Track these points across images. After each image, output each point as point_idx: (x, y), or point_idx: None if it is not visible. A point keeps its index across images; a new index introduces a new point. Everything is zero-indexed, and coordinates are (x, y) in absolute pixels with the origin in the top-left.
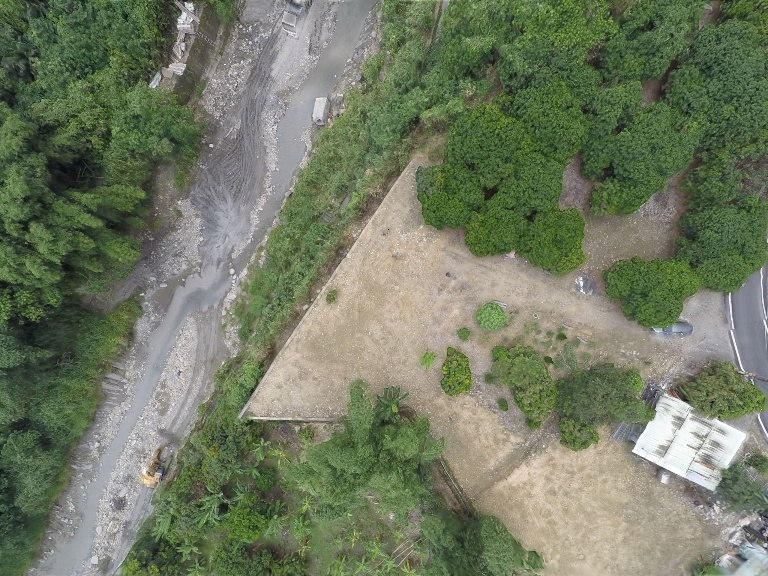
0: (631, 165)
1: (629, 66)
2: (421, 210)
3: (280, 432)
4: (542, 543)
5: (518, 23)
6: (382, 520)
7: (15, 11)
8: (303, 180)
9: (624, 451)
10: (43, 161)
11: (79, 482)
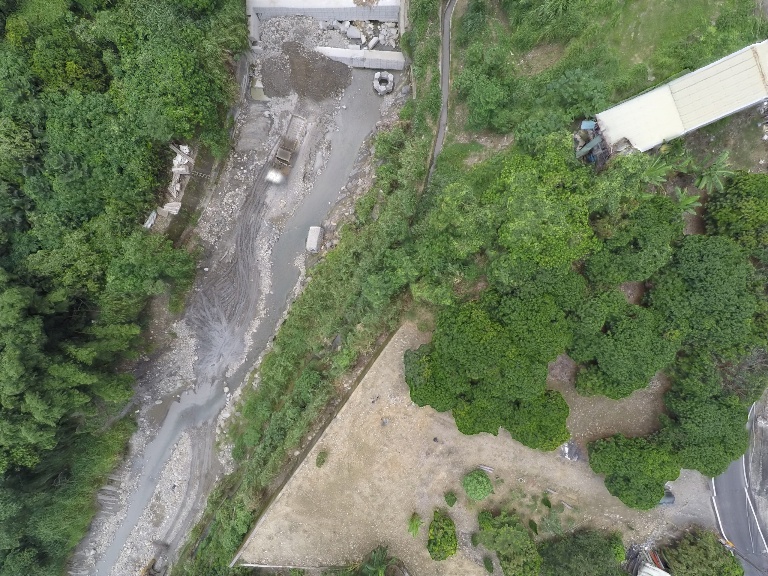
0: (614, 369)
1: (613, 277)
2: None
3: None
4: None
5: (503, 244)
6: None
7: (12, 169)
8: (296, 314)
9: None
10: (39, 325)
11: None
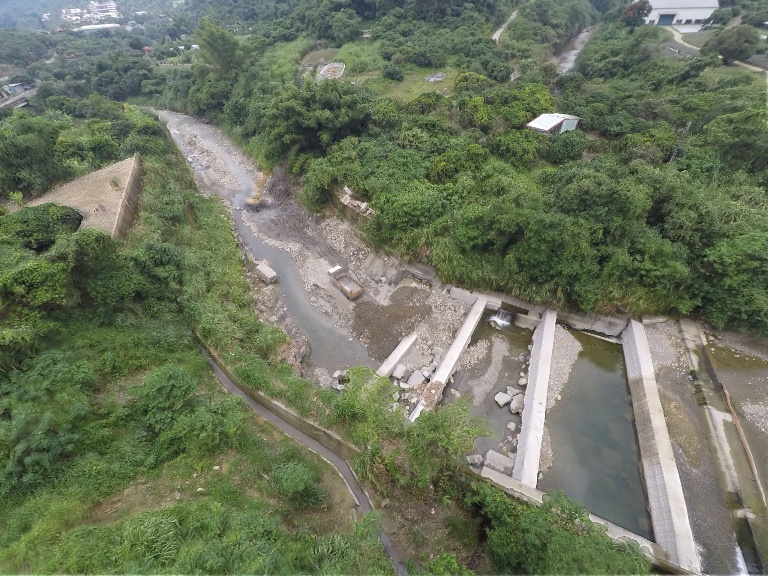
0: None
1: None
2: None
3: None
4: None
5: None
6: None
7: None
8: None
9: None
10: (310, 125)
11: None
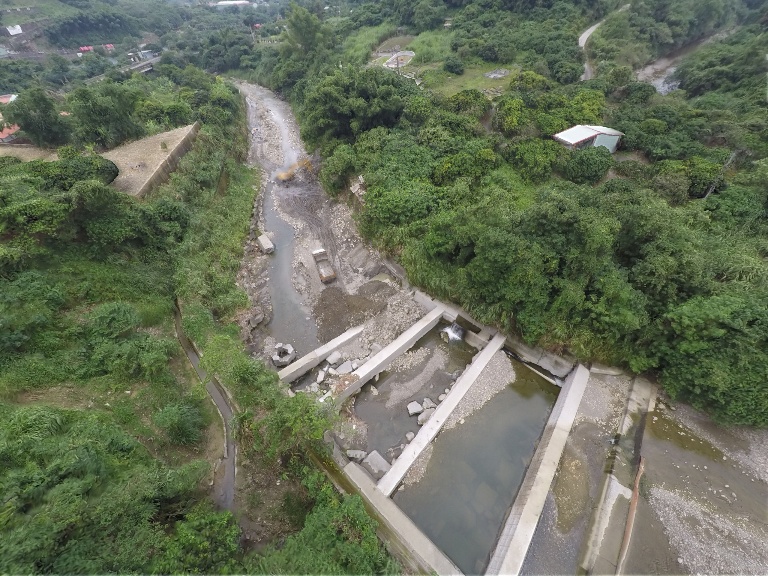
0: None
1: None
2: None
3: None
4: None
5: None
6: None
7: None
8: None
9: None
10: (344, 111)
11: None
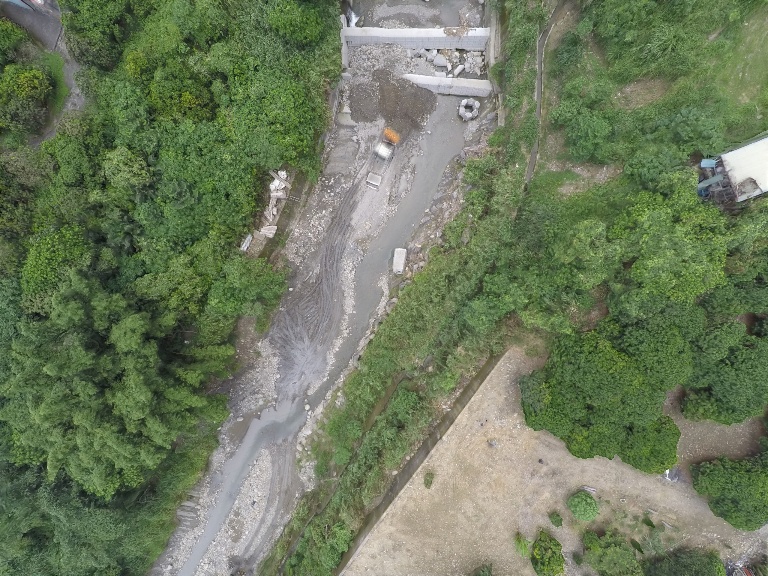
0: (733, 397)
1: (735, 309)
2: (516, 398)
3: None
4: None
5: (637, 279)
6: None
7: (124, 196)
8: (385, 334)
9: None
10: (154, 349)
11: None
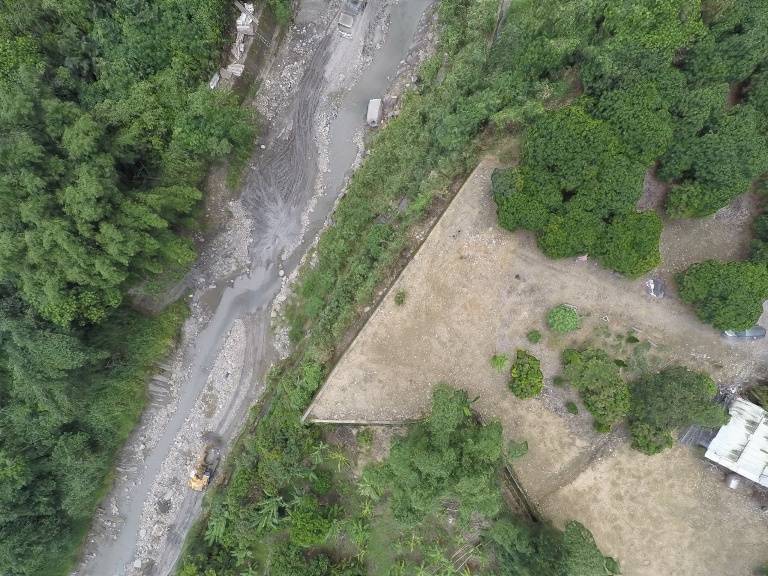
0: (717, 167)
1: (717, 68)
2: (490, 212)
3: (337, 435)
4: (607, 548)
5: (610, 24)
6: (441, 524)
7: (81, 11)
8: (359, 181)
9: (692, 455)
10: (111, 161)
11: (123, 485)
